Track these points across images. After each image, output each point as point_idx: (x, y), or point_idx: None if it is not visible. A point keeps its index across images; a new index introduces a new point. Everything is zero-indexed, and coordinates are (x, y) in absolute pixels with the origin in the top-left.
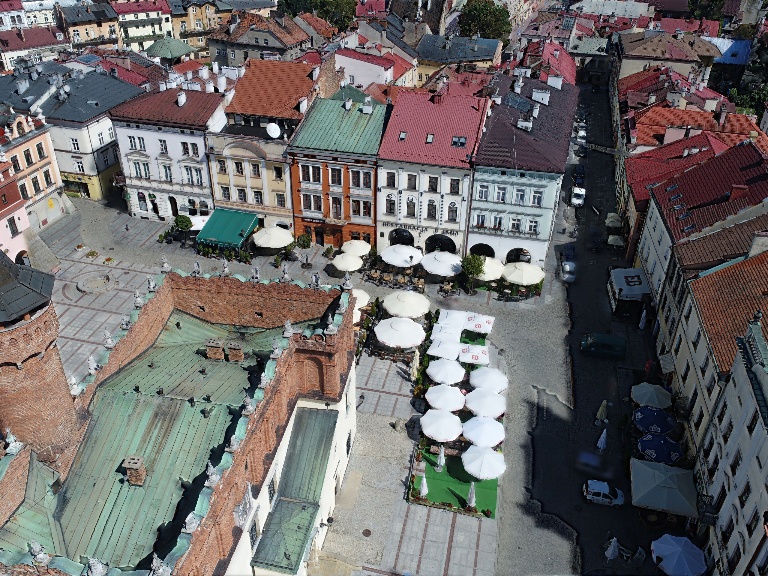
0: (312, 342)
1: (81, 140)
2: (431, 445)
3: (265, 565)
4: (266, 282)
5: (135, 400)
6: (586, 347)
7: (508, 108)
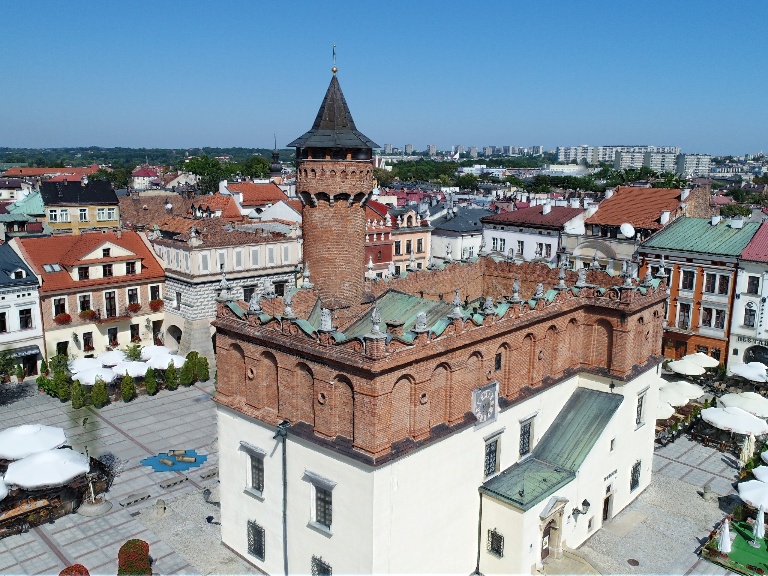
0: (605, 299)
1: (454, 248)
2: (748, 517)
3: (494, 493)
4: (574, 271)
5: (416, 302)
6: None
7: None
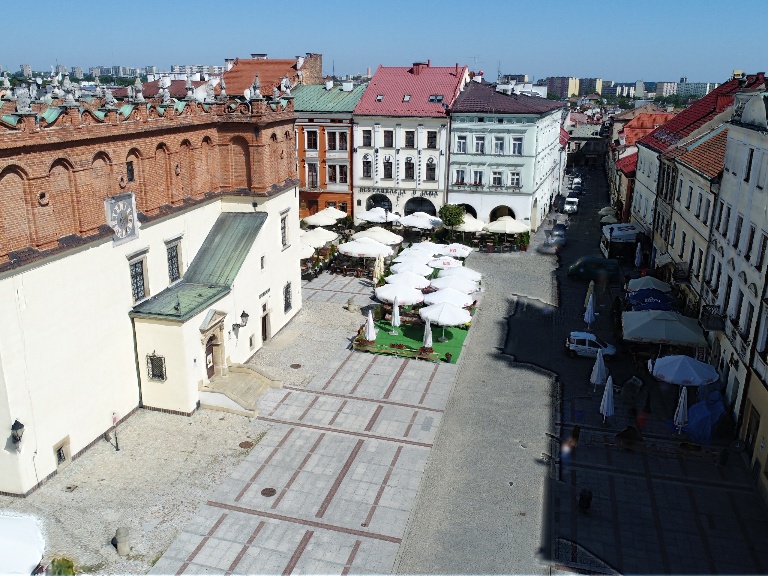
0: (237, 114)
1: None
2: (386, 313)
3: (147, 314)
4: None
5: None
6: (574, 268)
7: (488, 87)
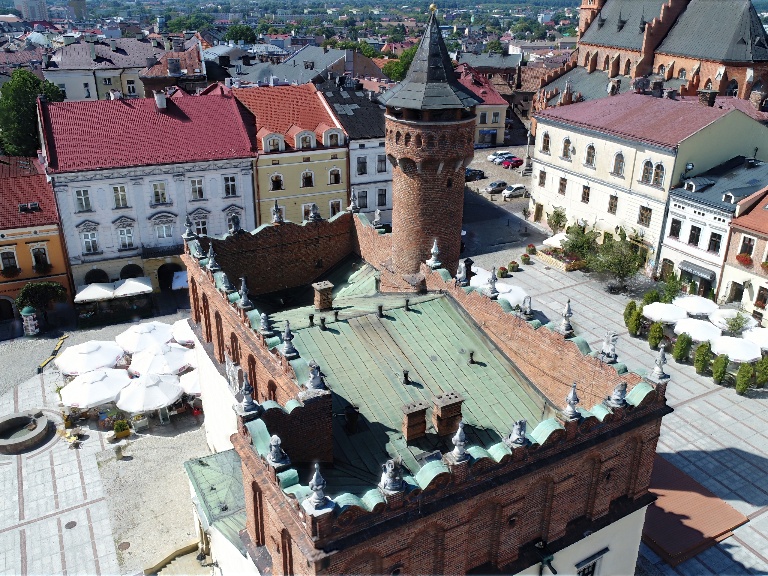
0: None
1: None
2: None
3: None
4: (497, 452)
5: None
6: None
7: None
